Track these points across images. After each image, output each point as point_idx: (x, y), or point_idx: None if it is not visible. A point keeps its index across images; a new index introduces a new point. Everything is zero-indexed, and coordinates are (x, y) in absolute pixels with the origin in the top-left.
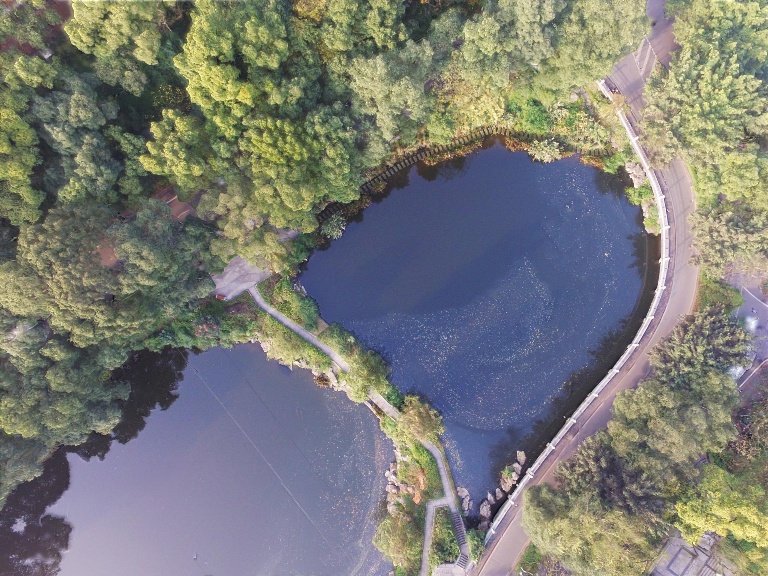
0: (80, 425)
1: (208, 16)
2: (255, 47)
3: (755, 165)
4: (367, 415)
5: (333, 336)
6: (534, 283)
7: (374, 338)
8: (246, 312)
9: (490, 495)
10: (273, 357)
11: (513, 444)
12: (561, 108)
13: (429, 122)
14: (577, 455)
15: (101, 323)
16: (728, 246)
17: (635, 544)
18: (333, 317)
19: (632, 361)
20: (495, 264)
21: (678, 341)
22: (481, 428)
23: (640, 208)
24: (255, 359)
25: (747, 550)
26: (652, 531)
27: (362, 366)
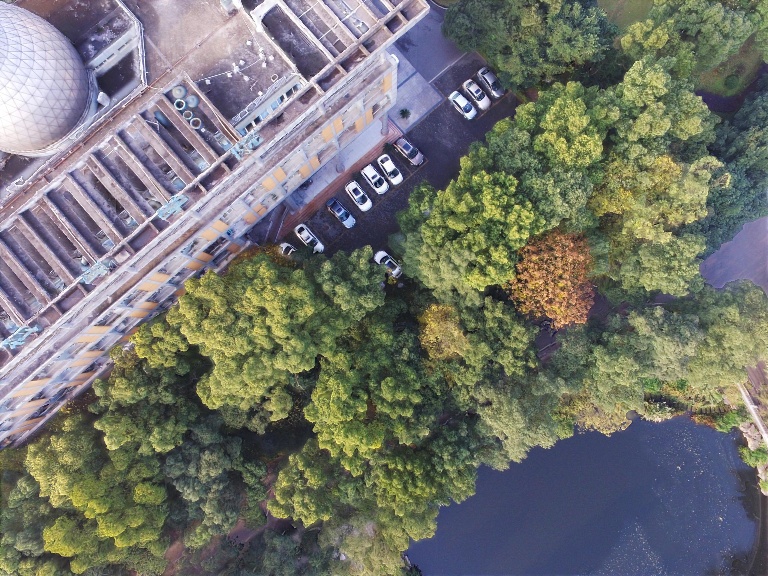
0: None
1: (346, 386)
2: (389, 402)
3: None
4: None
5: None
6: (646, 550)
7: None
8: None
9: None
10: None
11: None
12: None
13: None
14: None
15: None
16: None
17: None
18: None
19: None
20: (604, 529)
21: None
22: None
23: (755, 468)
24: None
25: None
26: None
27: None
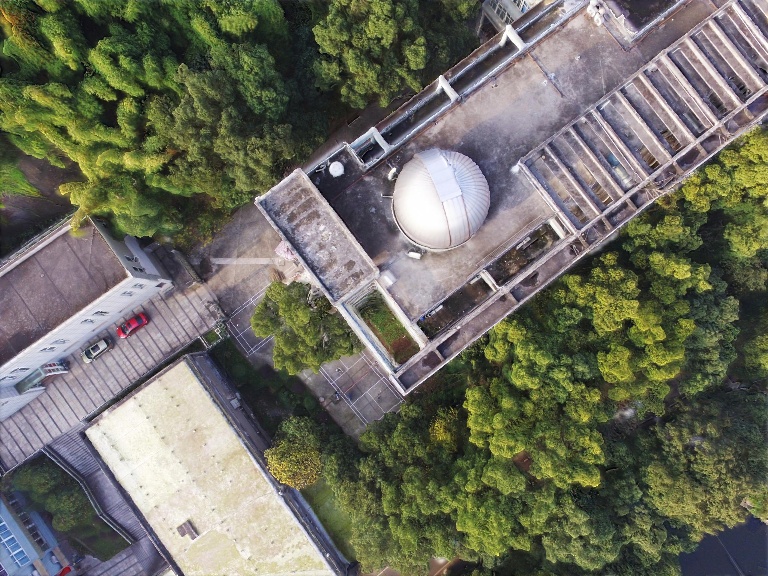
0: None
1: None
2: None
3: None
4: None
5: None
6: None
7: None
8: None
9: None
10: None
11: None
12: None
13: None
14: None
15: None
16: None
17: None
18: None
19: None
20: None
21: None
22: None
23: None
24: None
25: None
26: None
27: None
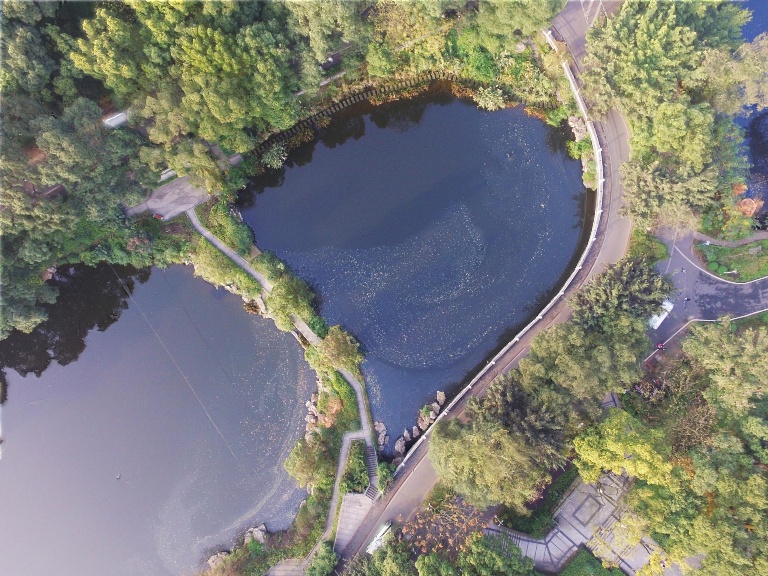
0: None
1: None
2: None
3: (684, 115)
4: (293, 345)
5: (263, 262)
6: (468, 228)
7: (305, 269)
8: (181, 233)
9: (406, 432)
10: (200, 274)
11: (434, 384)
12: (508, 57)
13: (368, 53)
14: (488, 391)
15: (18, 210)
16: (654, 196)
17: (519, 464)
18: (267, 245)
19: (557, 310)
20: (431, 206)
21: (595, 285)
22: (403, 365)
23: (580, 163)
24: (188, 282)
25: (638, 487)
26: (548, 464)
27: (281, 285)
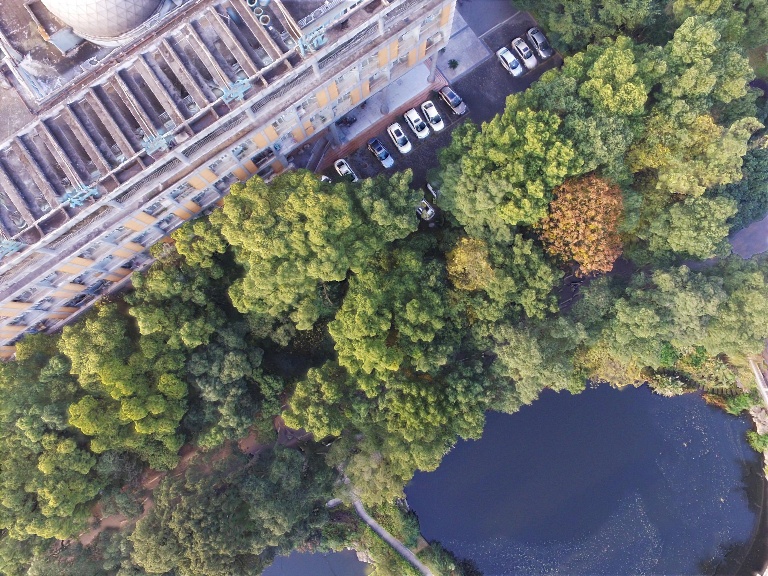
0: None
1: (373, 301)
2: (412, 325)
3: None
4: None
5: (434, 561)
6: (644, 522)
7: (473, 562)
8: (347, 522)
9: None
10: None
11: None
12: None
13: None
14: None
15: None
16: None
17: None
18: (433, 534)
19: None
20: (604, 497)
21: None
22: None
23: (761, 454)
24: (348, 564)
25: None
26: None
27: None
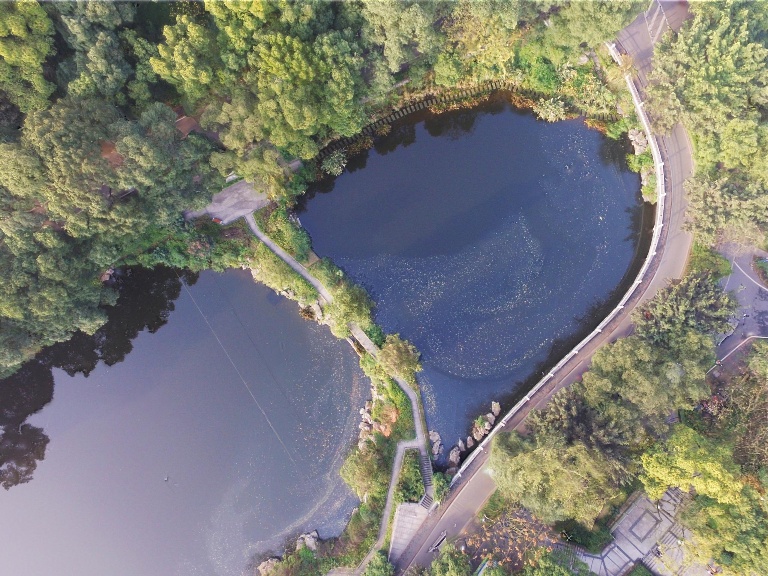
0: (66, 320)
1: None
2: None
3: (755, 133)
4: (348, 352)
5: (322, 268)
6: (526, 239)
7: (363, 276)
8: (240, 237)
9: (461, 442)
10: (261, 280)
11: (489, 394)
12: (570, 69)
13: (437, 62)
14: (550, 404)
15: (96, 213)
16: (721, 212)
17: (595, 480)
18: (325, 252)
19: (615, 323)
20: (489, 216)
21: (661, 300)
22: (459, 375)
23: (639, 176)
24: (244, 286)
25: (708, 506)
26: (615, 479)
27: (346, 293)
